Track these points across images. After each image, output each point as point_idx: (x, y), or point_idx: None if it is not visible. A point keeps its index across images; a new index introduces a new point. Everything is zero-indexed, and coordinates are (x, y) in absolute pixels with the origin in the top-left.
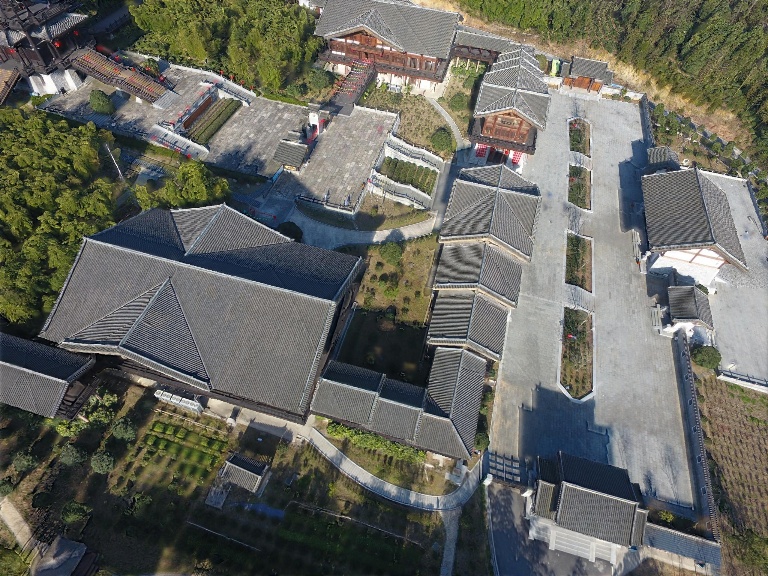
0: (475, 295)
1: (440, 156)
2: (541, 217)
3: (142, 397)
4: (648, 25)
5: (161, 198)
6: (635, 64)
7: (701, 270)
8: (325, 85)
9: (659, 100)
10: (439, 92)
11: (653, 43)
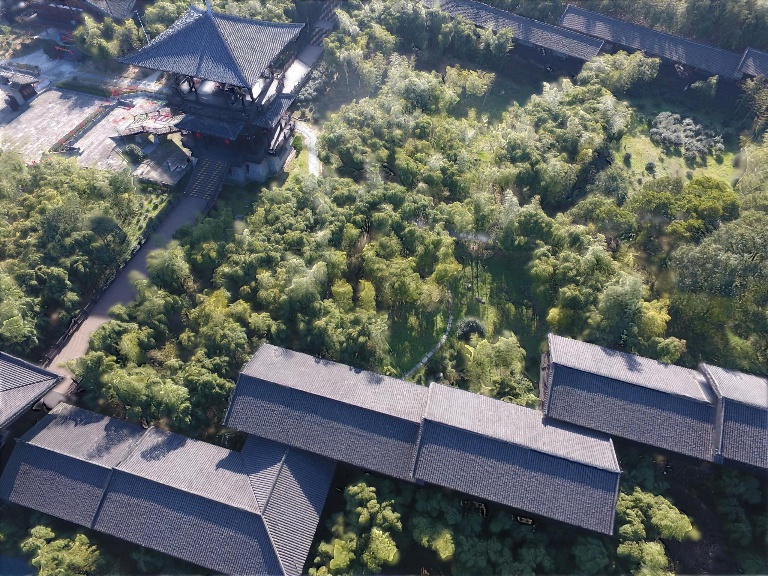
0: None
1: None
2: None
3: None
4: None
5: None
6: None
7: None
8: None
9: None
10: None
11: None
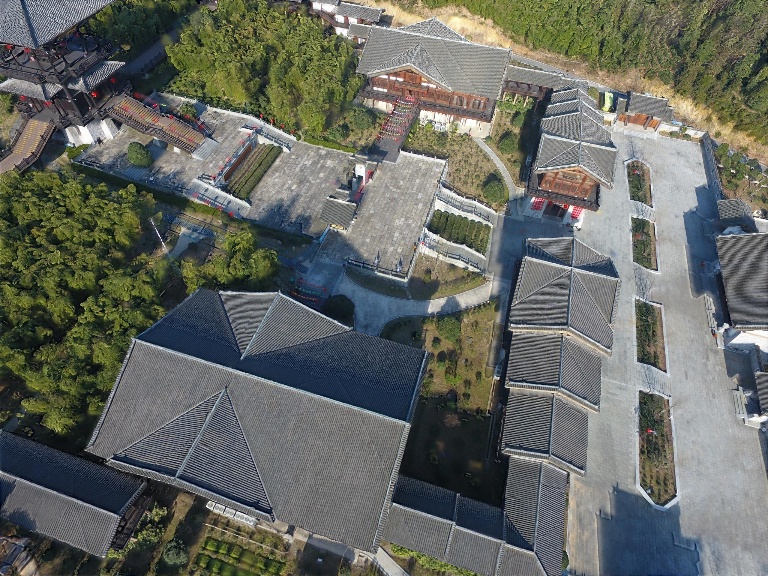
0: (554, 398)
1: (492, 208)
2: None
3: (192, 507)
4: (709, 56)
5: (207, 274)
6: (695, 98)
7: None
8: (368, 127)
9: (720, 137)
10: (486, 130)
11: (714, 75)
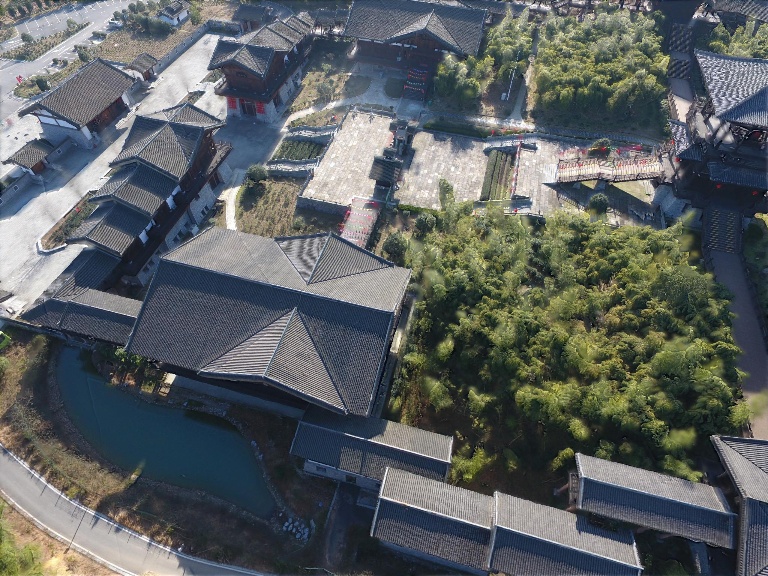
0: None
1: None
2: None
3: None
4: None
5: None
6: None
7: None
8: None
9: None
10: None
11: None
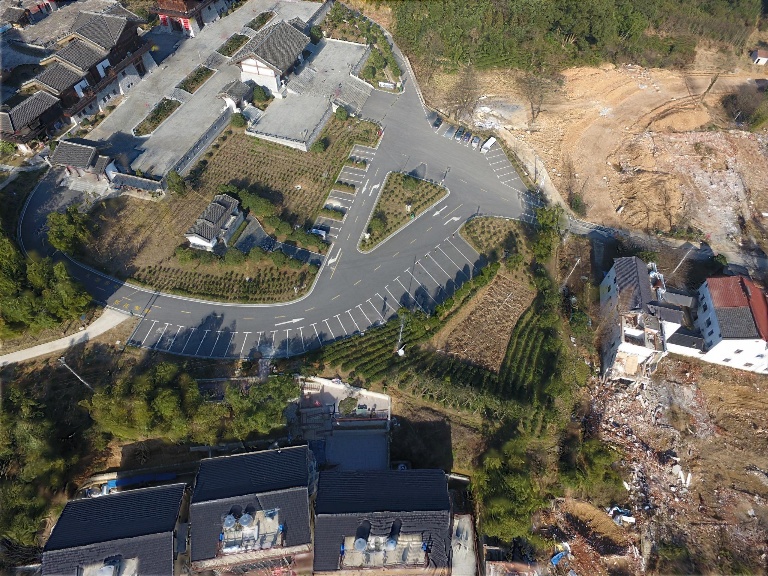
0: (57, 63)
1: None
2: (188, 58)
3: None
4: None
5: None
6: None
7: (267, 80)
8: None
9: (349, 3)
10: None
11: None
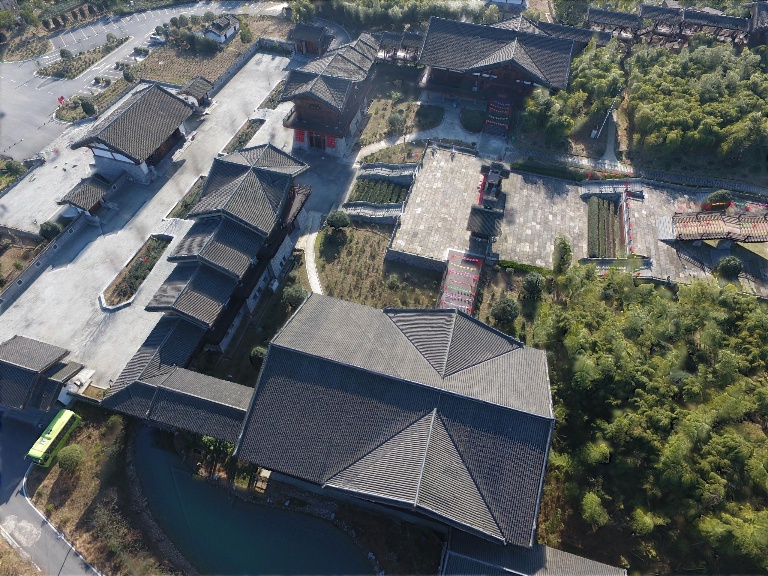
0: None
1: None
2: None
3: None
4: None
5: None
6: None
7: None
8: None
9: None
10: None
11: None
